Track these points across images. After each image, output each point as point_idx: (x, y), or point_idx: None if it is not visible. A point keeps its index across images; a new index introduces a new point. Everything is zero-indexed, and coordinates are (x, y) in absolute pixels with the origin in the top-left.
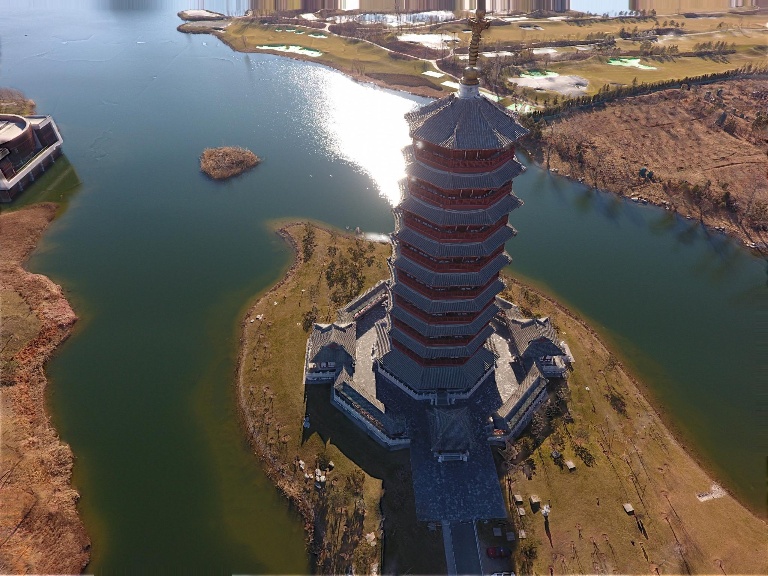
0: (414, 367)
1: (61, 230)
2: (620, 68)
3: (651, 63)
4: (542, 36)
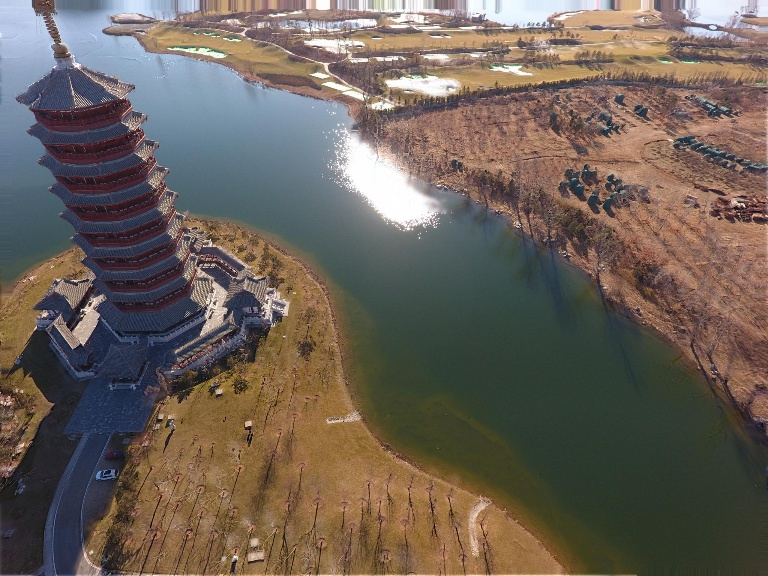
0: (118, 313)
1: None
2: (497, 73)
3: (530, 69)
4: (439, 43)
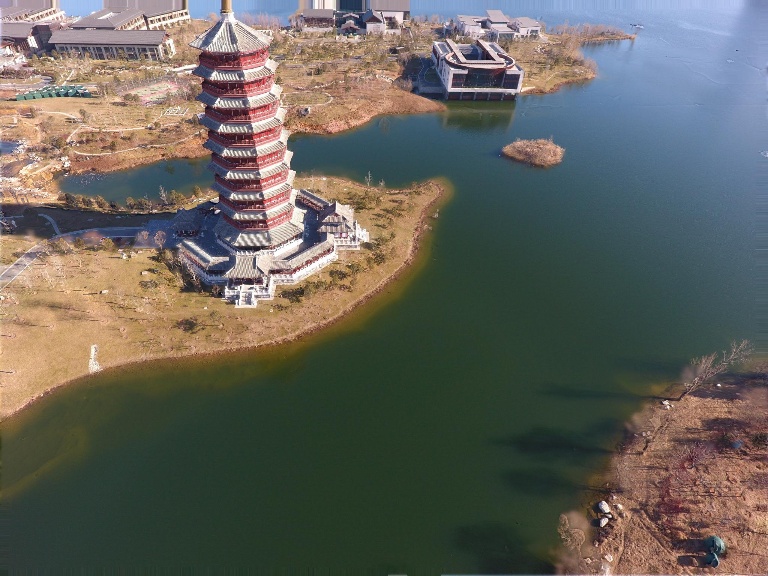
0: None
1: (419, 117)
2: None
3: None
4: None
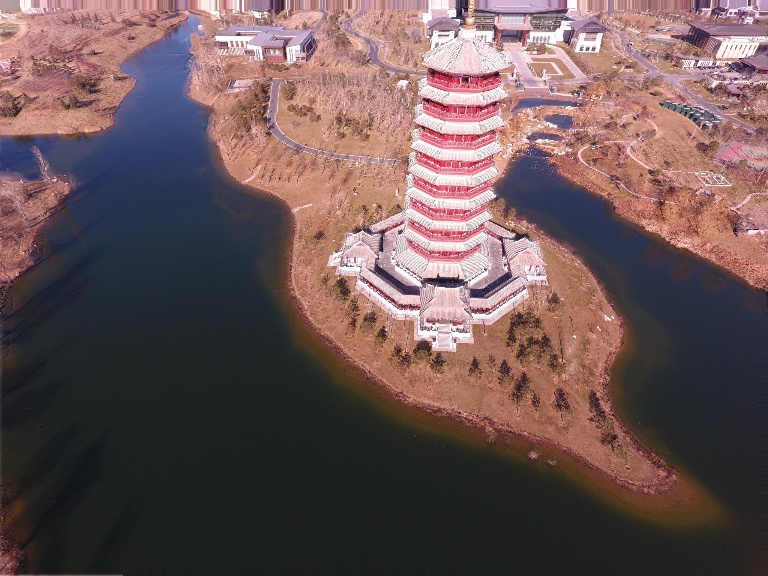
0: None
1: None
2: None
3: None
4: None
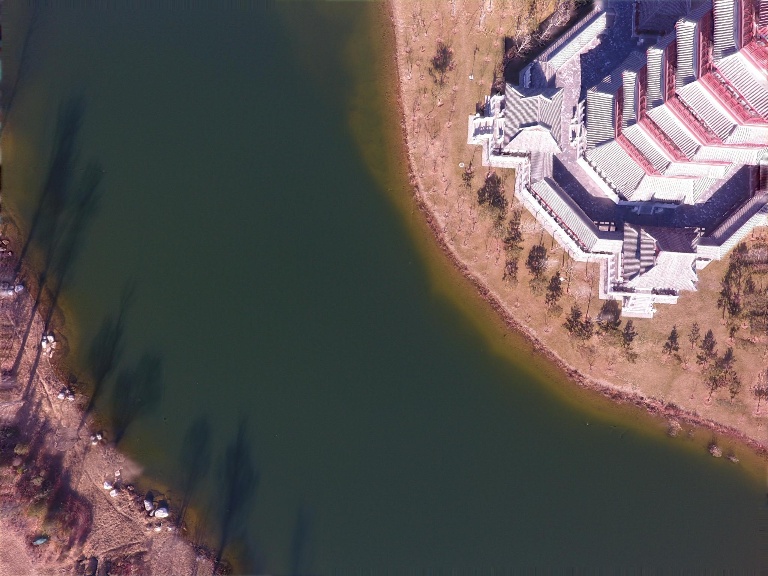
0: None
1: None
2: None
3: None
4: None
